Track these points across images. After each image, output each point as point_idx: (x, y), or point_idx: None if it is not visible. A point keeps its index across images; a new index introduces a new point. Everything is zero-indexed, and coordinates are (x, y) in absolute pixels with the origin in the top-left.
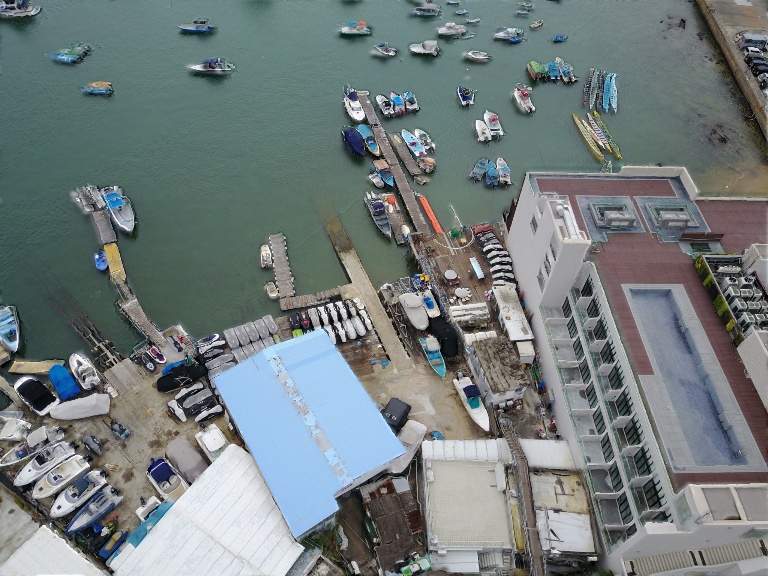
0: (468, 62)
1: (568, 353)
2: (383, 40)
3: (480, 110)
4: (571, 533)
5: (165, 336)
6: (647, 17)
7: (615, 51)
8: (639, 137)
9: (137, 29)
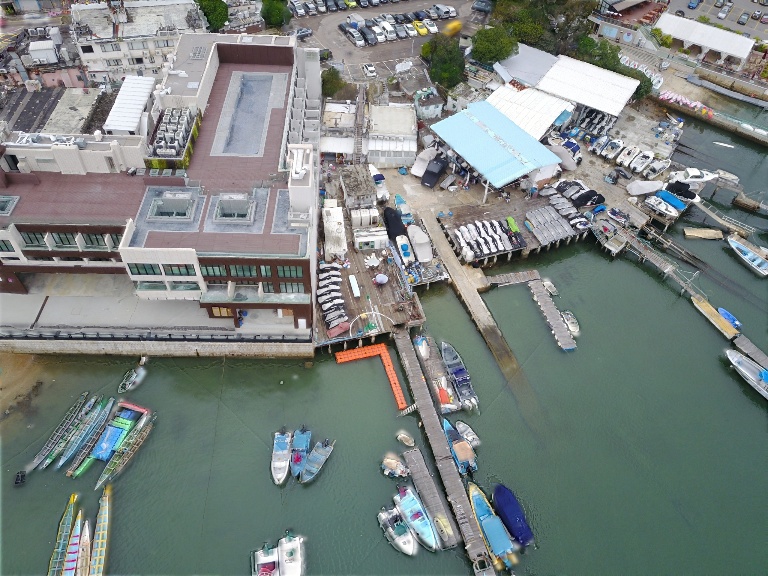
0: None
1: None
2: None
3: None
4: (337, 107)
5: None
6: None
7: None
8: None
9: None
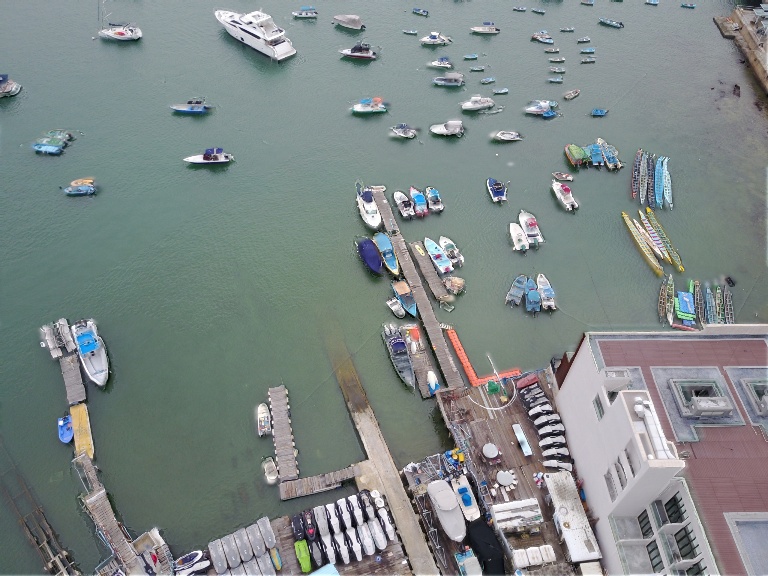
0: (497, 144)
1: None
2: (400, 120)
3: (514, 208)
4: None
5: (136, 546)
6: (696, 83)
7: (663, 126)
8: (701, 240)
9: (126, 110)
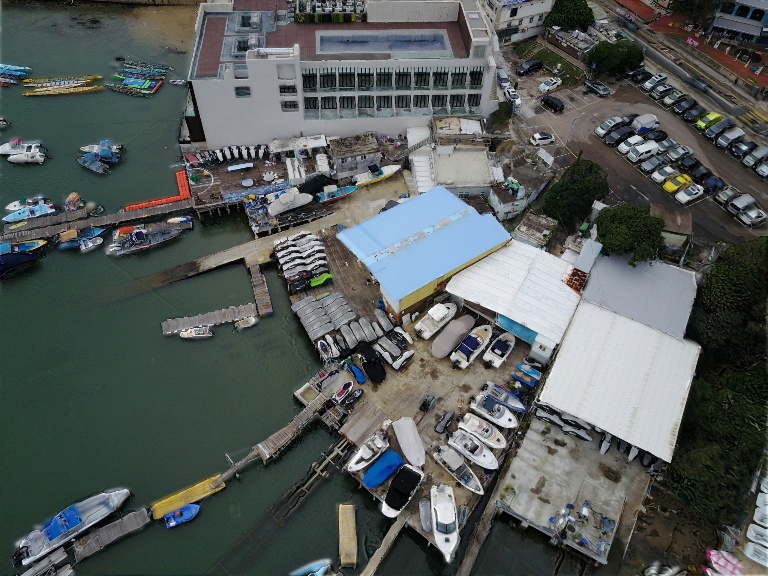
0: None
1: (345, 112)
2: None
3: None
4: (472, 127)
5: None
6: None
7: None
8: (71, 64)
9: None
